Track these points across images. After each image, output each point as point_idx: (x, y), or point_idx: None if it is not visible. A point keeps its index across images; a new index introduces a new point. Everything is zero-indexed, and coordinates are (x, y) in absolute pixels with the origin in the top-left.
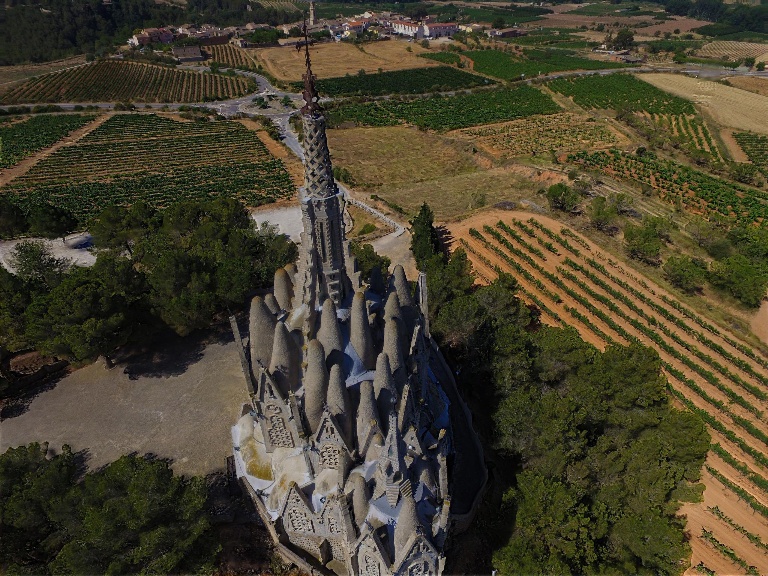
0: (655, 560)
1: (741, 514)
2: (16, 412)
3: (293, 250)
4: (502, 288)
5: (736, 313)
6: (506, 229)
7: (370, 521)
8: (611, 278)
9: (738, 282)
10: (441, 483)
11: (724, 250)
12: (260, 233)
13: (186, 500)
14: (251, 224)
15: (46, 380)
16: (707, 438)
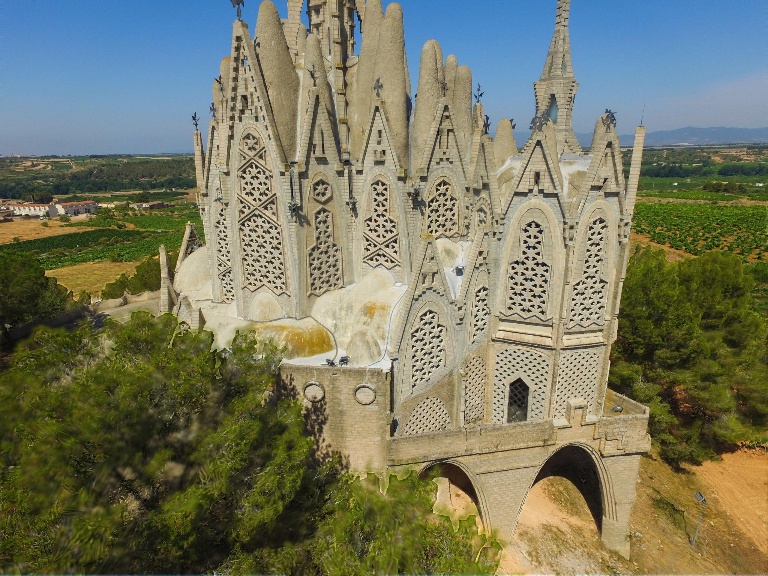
0: None
1: None
2: None
3: (59, 293)
4: None
5: None
6: None
7: (573, 178)
8: None
9: None
10: None
11: None
12: None
13: None
14: None
15: None
16: None
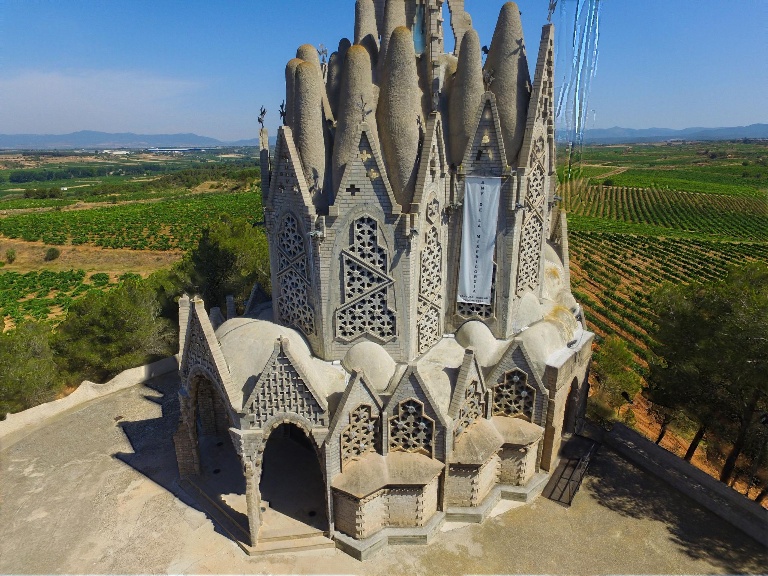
0: None
1: None
2: None
3: None
4: None
5: None
6: None
7: None
8: None
9: None
10: None
11: None
12: None
13: None
14: None
15: None
16: None
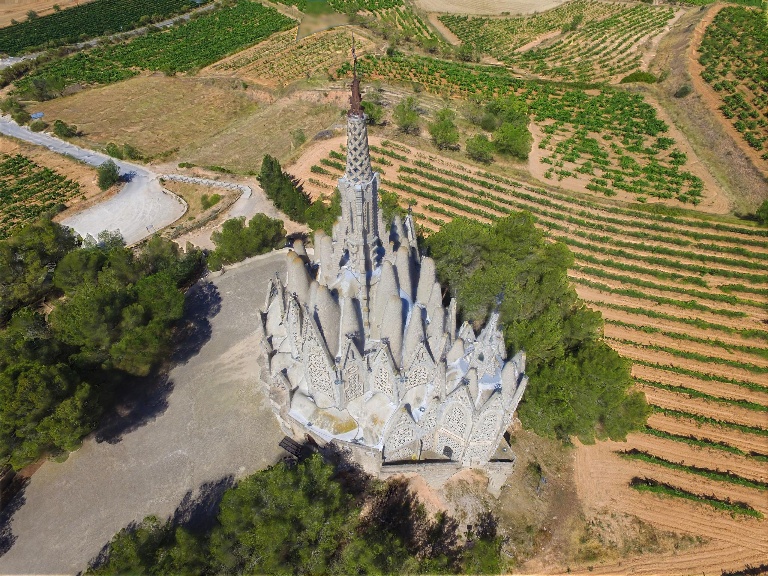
0: (592, 335)
1: (587, 294)
2: (1, 548)
3: (174, 248)
4: (388, 209)
5: (519, 167)
6: (340, 157)
7: (483, 394)
8: (438, 171)
9: (513, 144)
10: (502, 349)
11: (491, 122)
12: (101, 246)
13: (317, 476)
14: (87, 240)
15: (2, 502)
16: (572, 255)
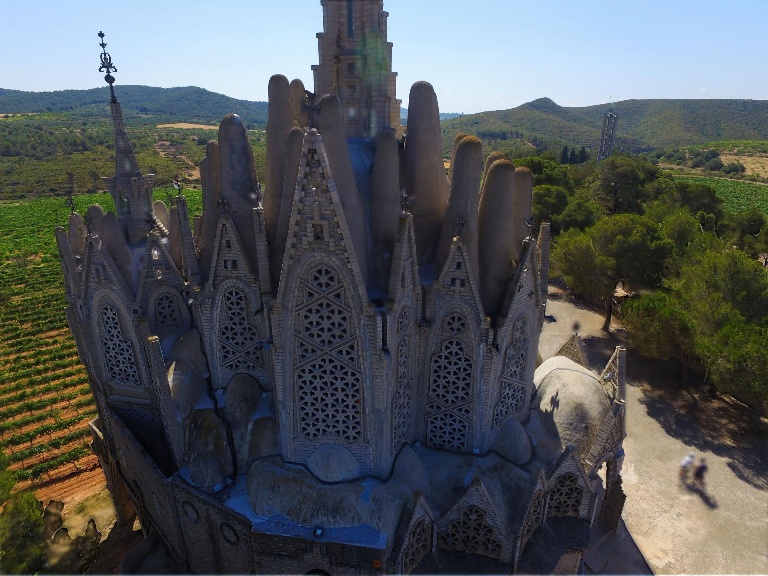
0: None
1: None
2: (553, 298)
3: None
4: None
5: None
6: None
7: None
8: None
9: None
10: None
11: None
12: None
13: None
14: None
15: (594, 309)
16: None
